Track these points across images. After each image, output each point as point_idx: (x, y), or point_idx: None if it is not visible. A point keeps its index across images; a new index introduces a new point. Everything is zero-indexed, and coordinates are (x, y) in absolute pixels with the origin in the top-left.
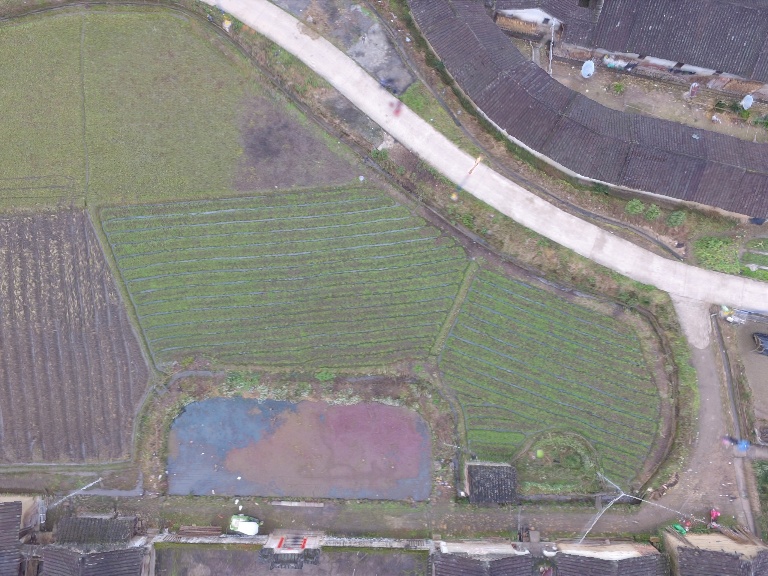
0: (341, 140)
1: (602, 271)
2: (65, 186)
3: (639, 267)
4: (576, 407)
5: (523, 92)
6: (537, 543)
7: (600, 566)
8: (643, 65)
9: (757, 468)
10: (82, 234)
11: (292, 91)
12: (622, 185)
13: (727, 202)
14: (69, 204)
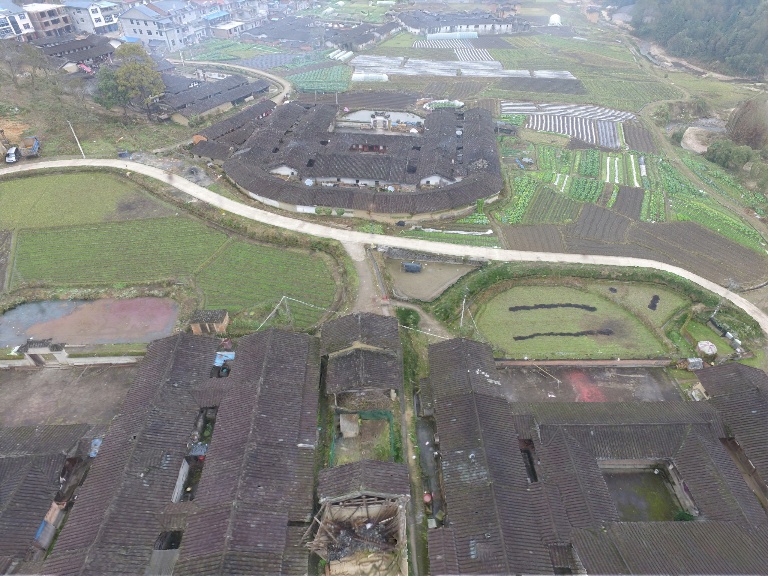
0: (171, 203)
1: None
2: (7, 224)
3: (323, 232)
4: None
5: (266, 180)
6: None
7: (263, 333)
8: (342, 185)
9: (395, 306)
10: (4, 239)
11: (152, 190)
12: (314, 205)
13: (369, 207)
14: (5, 229)
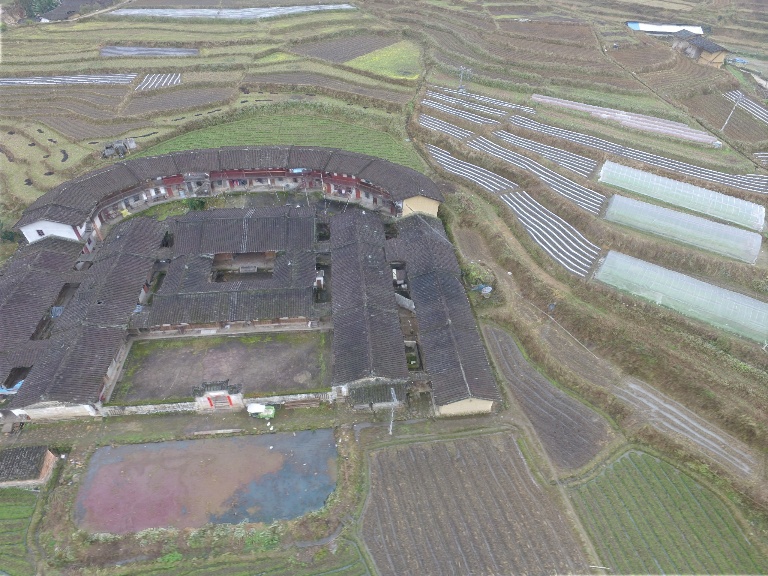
0: None
1: None
2: None
3: None
4: None
5: None
6: (7, 423)
7: None
8: None
9: None
10: None
11: None
12: None
13: None
14: None
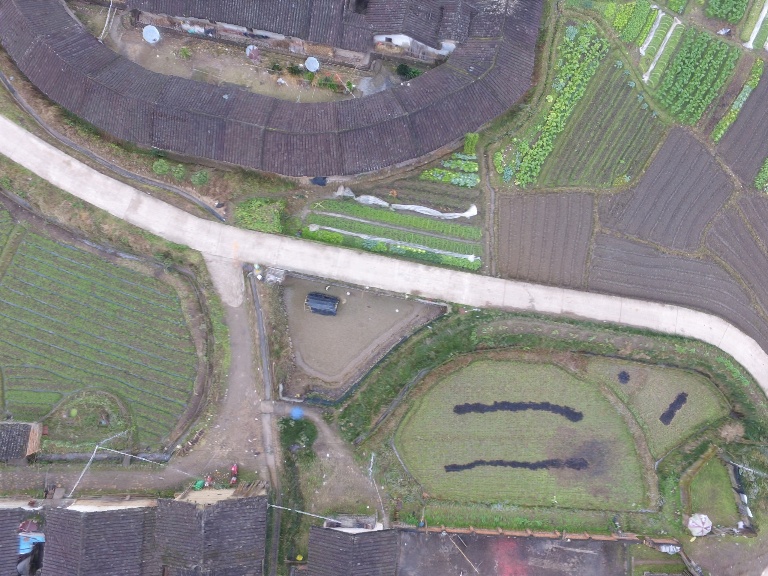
0: None
1: (136, 231)
2: None
3: (173, 227)
4: (115, 367)
5: (54, 56)
6: (59, 500)
7: (74, 518)
8: (222, 30)
9: (279, 423)
10: None
11: None
12: (153, 146)
13: (255, 161)
14: None
